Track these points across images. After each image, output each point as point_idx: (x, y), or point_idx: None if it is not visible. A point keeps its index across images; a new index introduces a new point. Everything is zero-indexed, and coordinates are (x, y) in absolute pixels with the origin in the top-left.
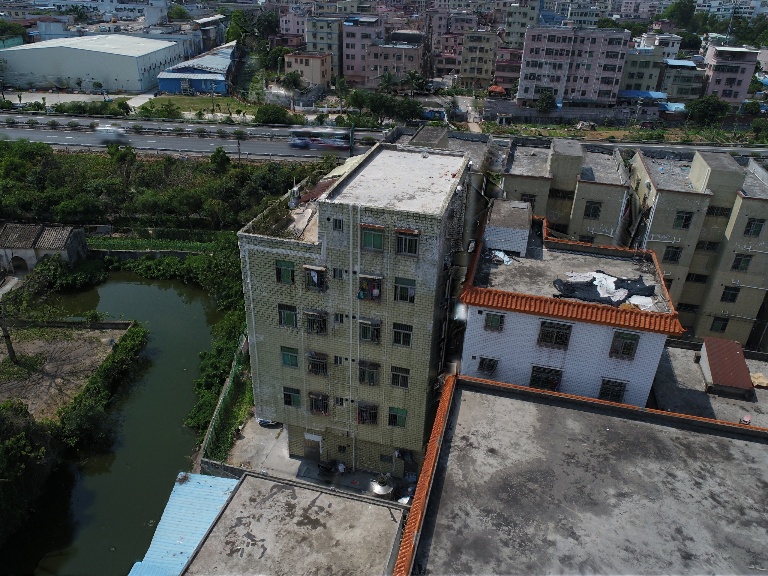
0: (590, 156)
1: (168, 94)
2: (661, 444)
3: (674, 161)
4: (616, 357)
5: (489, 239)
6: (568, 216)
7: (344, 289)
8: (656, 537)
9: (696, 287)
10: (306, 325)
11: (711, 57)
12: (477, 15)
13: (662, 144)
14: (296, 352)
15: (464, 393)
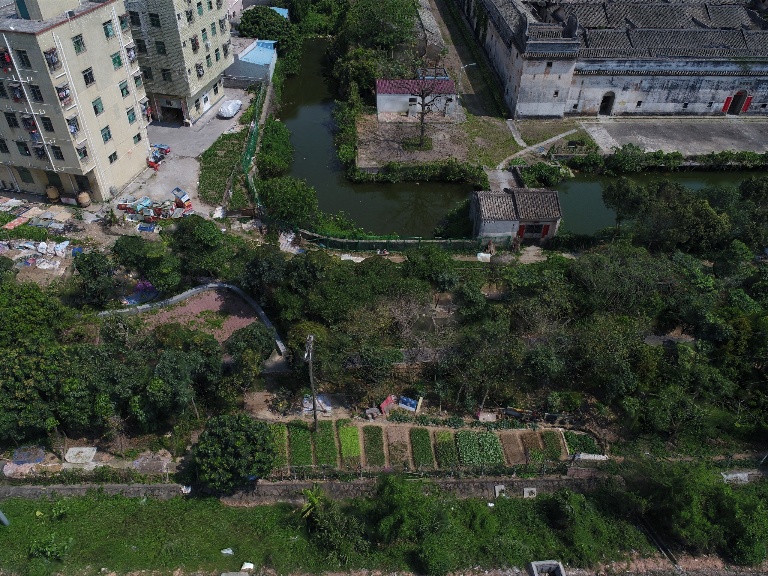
0: None
1: None
2: None
3: None
4: None
5: None
6: None
7: None
8: None
9: None
10: None
11: None
12: None
13: None
14: None
15: None
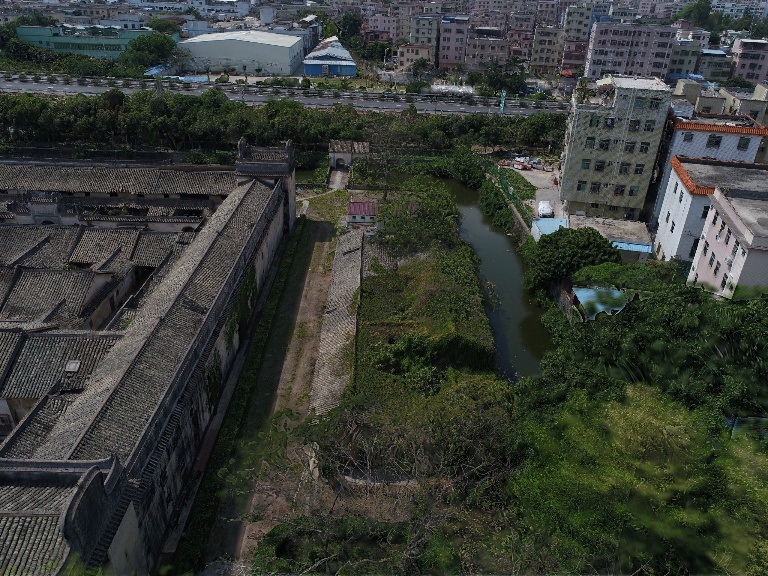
0: None
1: (312, 76)
2: None
3: (742, 93)
4: (740, 149)
5: (675, 111)
6: None
7: (621, 127)
8: (767, 185)
9: None
10: (598, 147)
11: (737, 47)
12: (534, 15)
13: None
14: (590, 161)
15: None
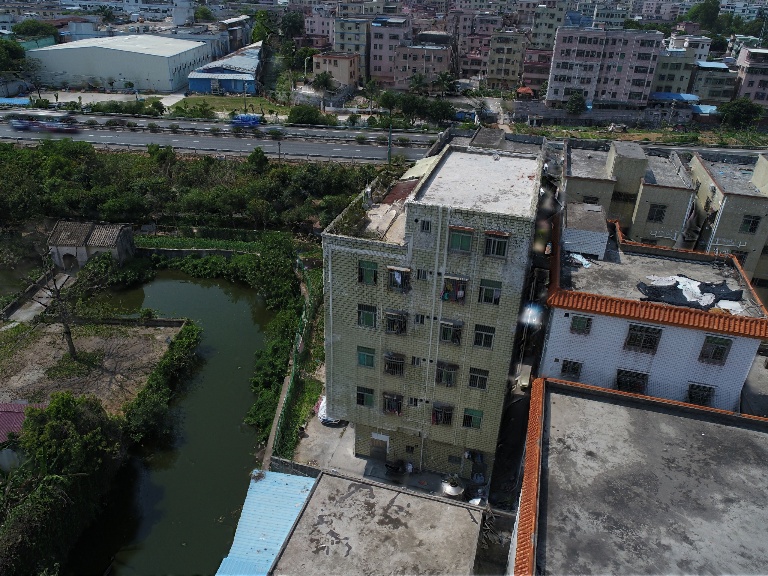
0: None
1: (198, 94)
2: (760, 450)
3: (733, 165)
4: (706, 362)
5: (567, 242)
6: (629, 219)
7: (427, 290)
8: None
9: (759, 292)
10: (385, 325)
11: (744, 59)
12: (502, 16)
13: (697, 147)
14: (373, 352)
15: (552, 396)
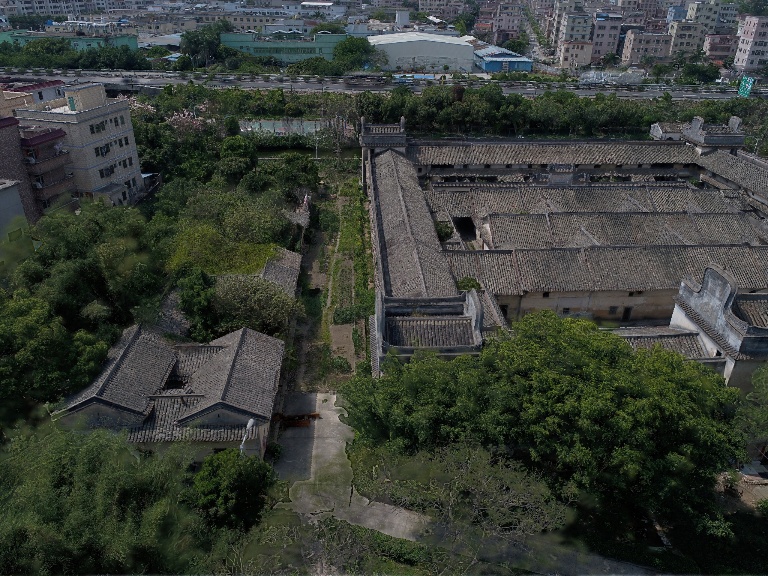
0: None
1: (493, 73)
2: None
3: None
4: None
5: None
6: None
7: None
8: None
9: None
10: None
11: None
12: None
13: None
14: None
15: None
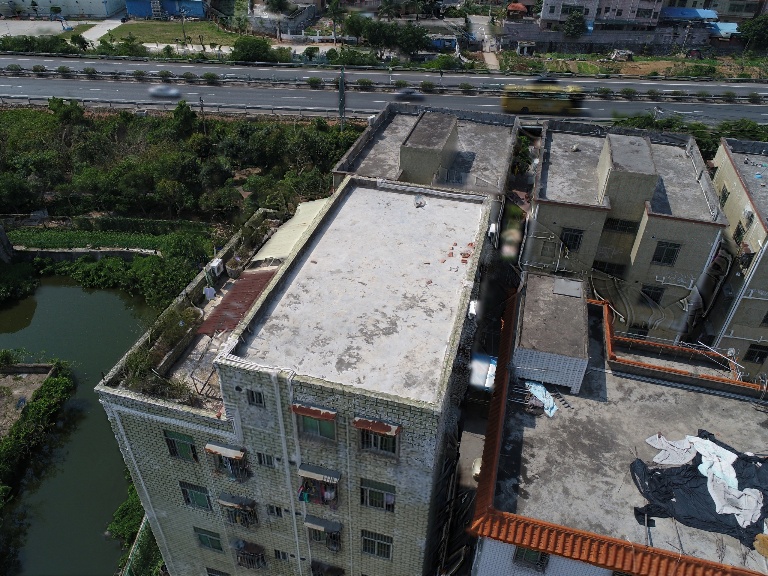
0: (655, 151)
1: (137, 19)
2: None
3: None
4: None
5: (521, 367)
6: (627, 254)
7: (278, 479)
8: None
9: None
10: None
11: None
12: None
13: (715, 82)
14: (217, 536)
15: None
